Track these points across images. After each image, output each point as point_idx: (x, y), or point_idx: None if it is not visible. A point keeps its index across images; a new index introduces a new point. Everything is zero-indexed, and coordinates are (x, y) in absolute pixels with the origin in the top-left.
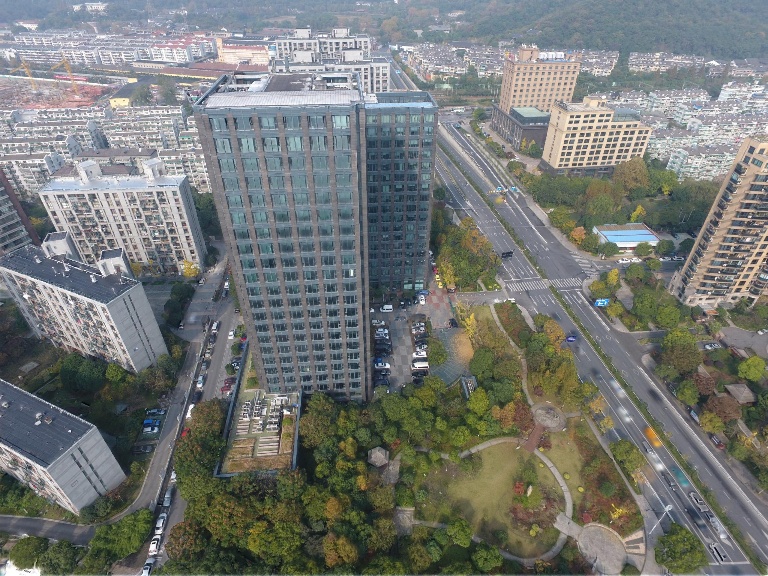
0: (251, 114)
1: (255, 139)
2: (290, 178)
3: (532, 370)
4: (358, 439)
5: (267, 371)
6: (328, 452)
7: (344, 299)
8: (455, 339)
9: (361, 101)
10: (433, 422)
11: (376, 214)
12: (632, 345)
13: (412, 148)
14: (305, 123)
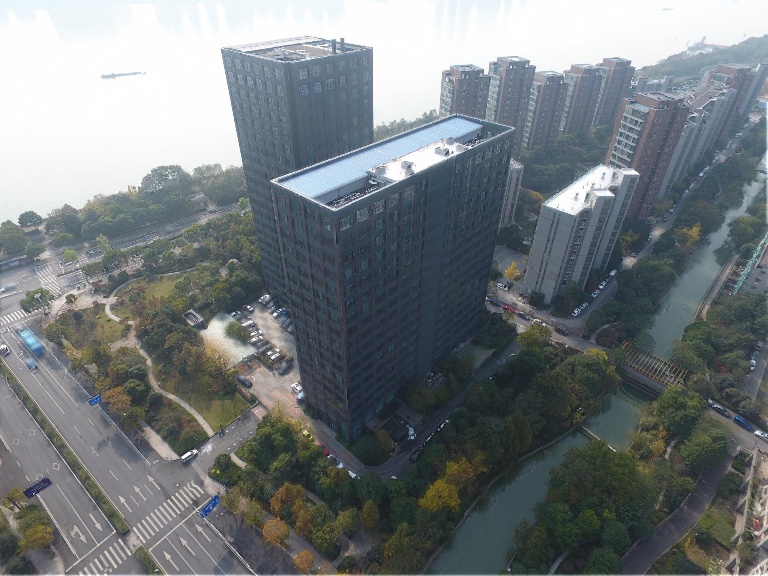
0: None
1: None
2: None
3: None
4: None
5: None
6: None
7: None
8: (228, 353)
9: None
10: None
11: None
12: (6, 482)
13: None
14: None
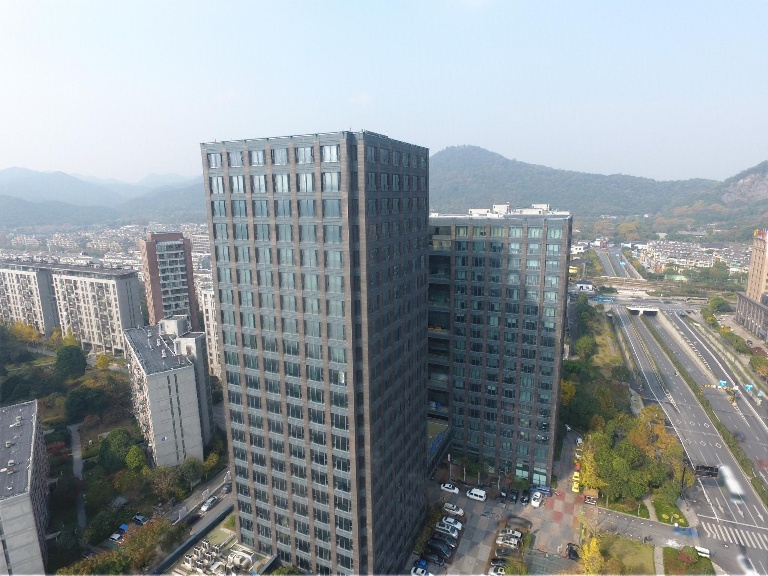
0: (242, 147)
1: (244, 177)
2: (275, 227)
3: None
4: None
5: (241, 505)
6: None
7: (333, 419)
8: None
9: None
10: None
11: (480, 354)
12: None
13: (530, 271)
14: (292, 156)
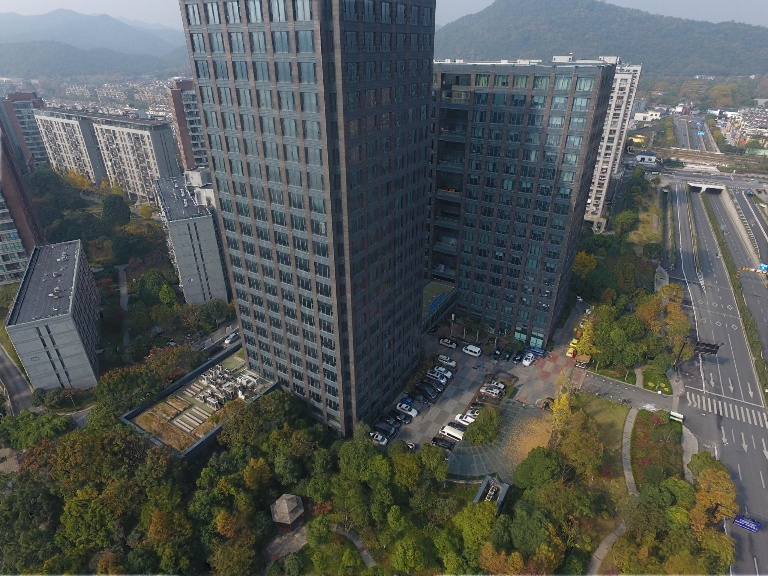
0: None
1: (218, 4)
2: (252, 64)
3: (627, 534)
4: (275, 468)
5: (247, 339)
6: (230, 461)
7: (316, 267)
8: (528, 423)
9: None
10: (387, 509)
11: (490, 219)
12: None
13: (552, 129)
14: None
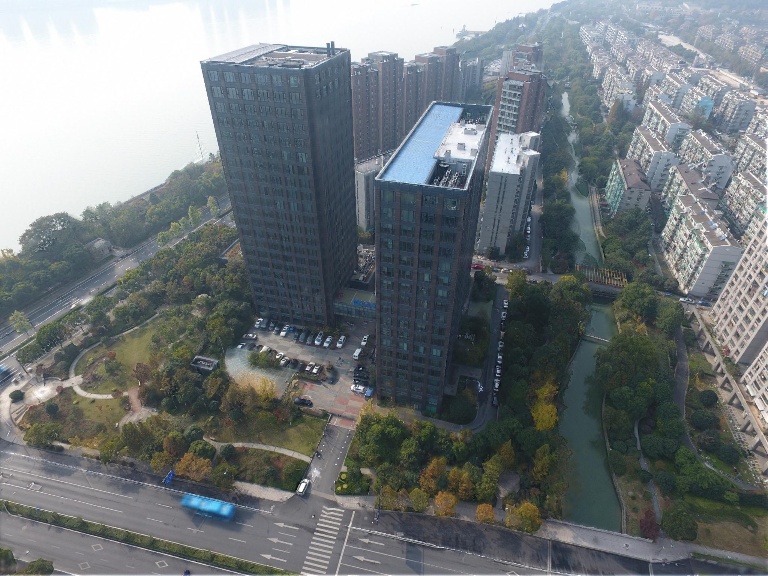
0: None
1: None
2: None
3: None
4: None
5: None
6: None
7: None
8: None
9: (205, 62)
10: None
11: None
12: None
13: None
14: None
